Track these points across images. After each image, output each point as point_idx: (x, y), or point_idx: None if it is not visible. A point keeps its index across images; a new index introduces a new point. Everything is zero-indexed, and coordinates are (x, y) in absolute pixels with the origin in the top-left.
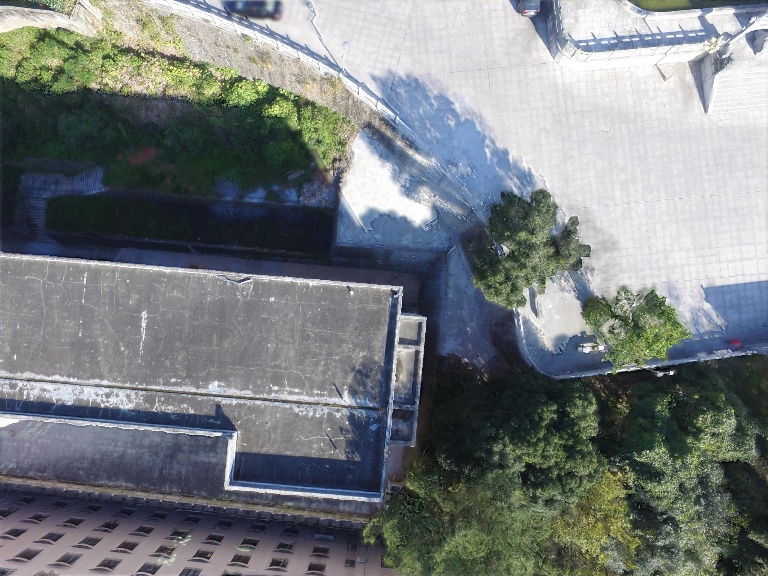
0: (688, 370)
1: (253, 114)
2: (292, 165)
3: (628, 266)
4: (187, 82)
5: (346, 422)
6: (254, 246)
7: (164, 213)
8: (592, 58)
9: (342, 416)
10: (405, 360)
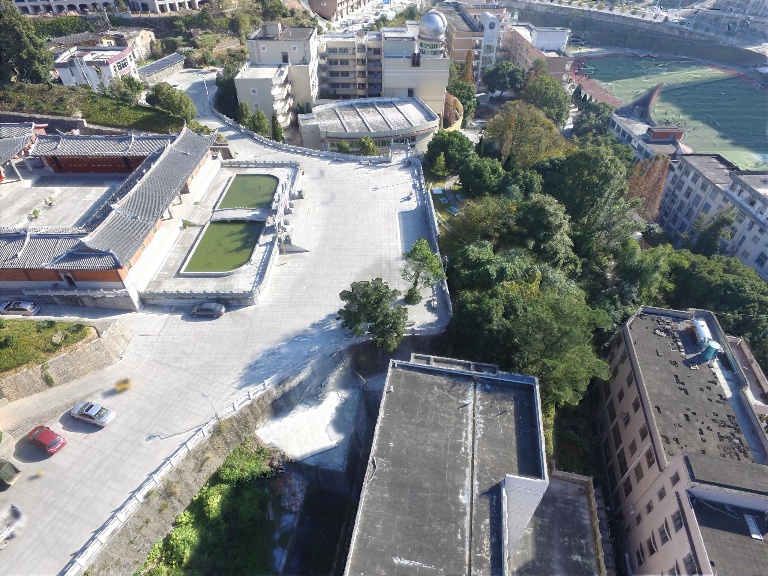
0: None
1: None
2: (265, 498)
3: None
4: None
5: (486, 403)
6: None
7: None
8: (264, 284)
9: (482, 405)
10: None
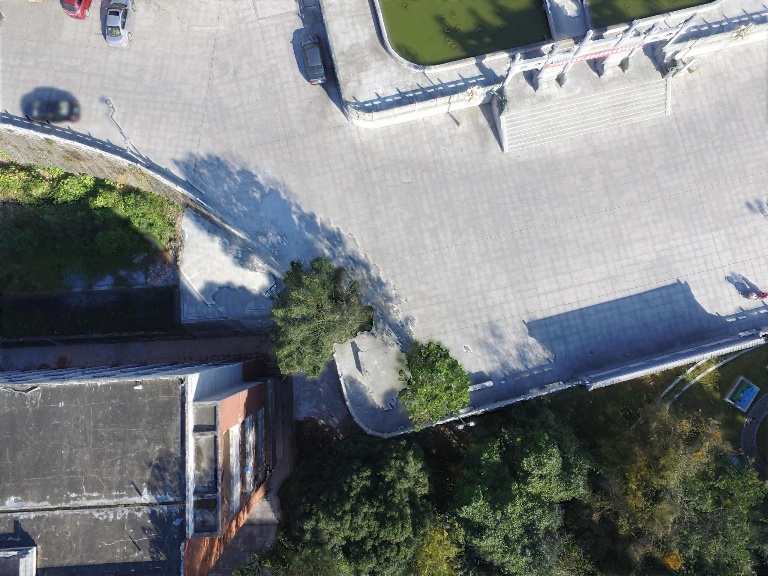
0: (520, 409)
1: (84, 207)
2: (127, 251)
3: (448, 311)
4: (14, 186)
5: (148, 521)
6: (113, 332)
7: (19, 312)
8: (378, 117)
9: (143, 515)
10: (205, 447)
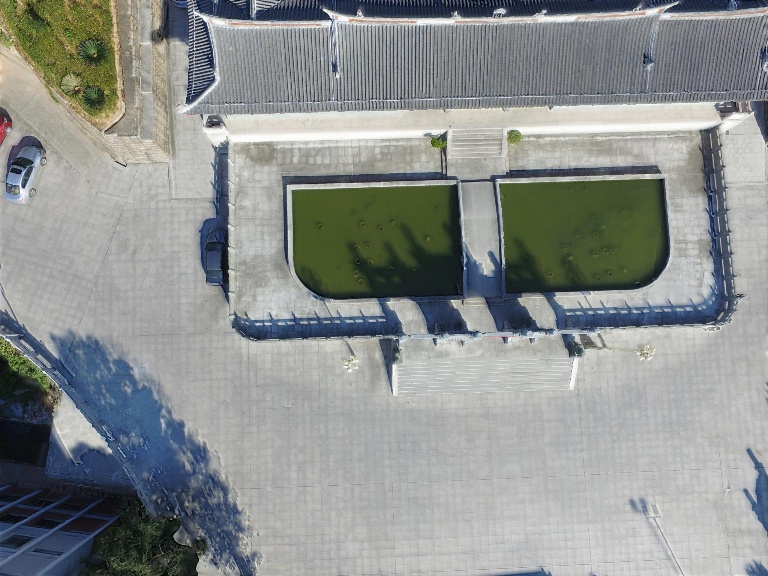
0: None
1: None
2: (0, 393)
3: (298, 555)
4: None
5: None
6: None
7: None
8: None
9: None
10: None
